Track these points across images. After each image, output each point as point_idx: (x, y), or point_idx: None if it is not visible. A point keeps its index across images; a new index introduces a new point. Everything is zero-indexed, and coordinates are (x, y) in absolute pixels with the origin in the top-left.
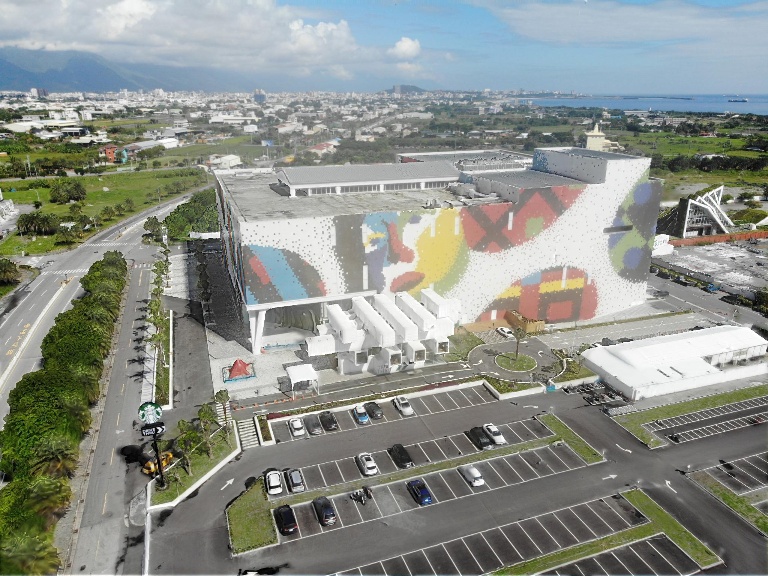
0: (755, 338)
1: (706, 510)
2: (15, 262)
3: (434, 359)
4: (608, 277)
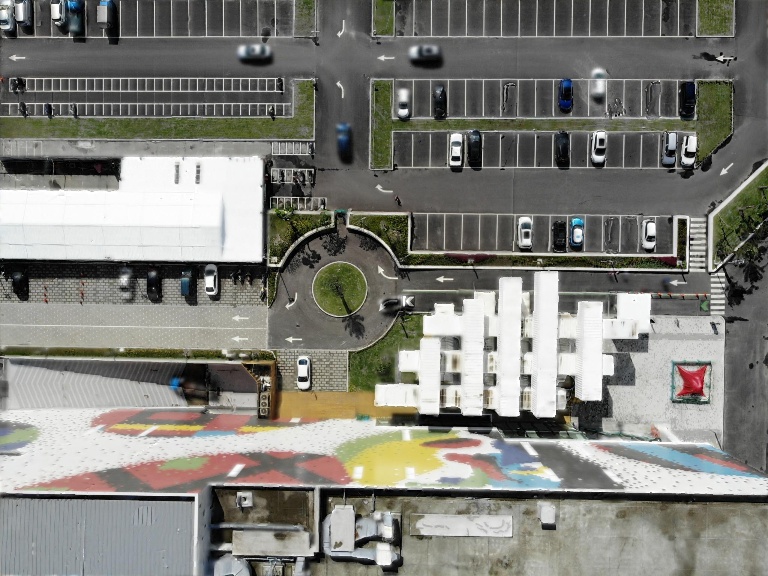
0: (0, 202)
1: None
2: None
3: None
4: None
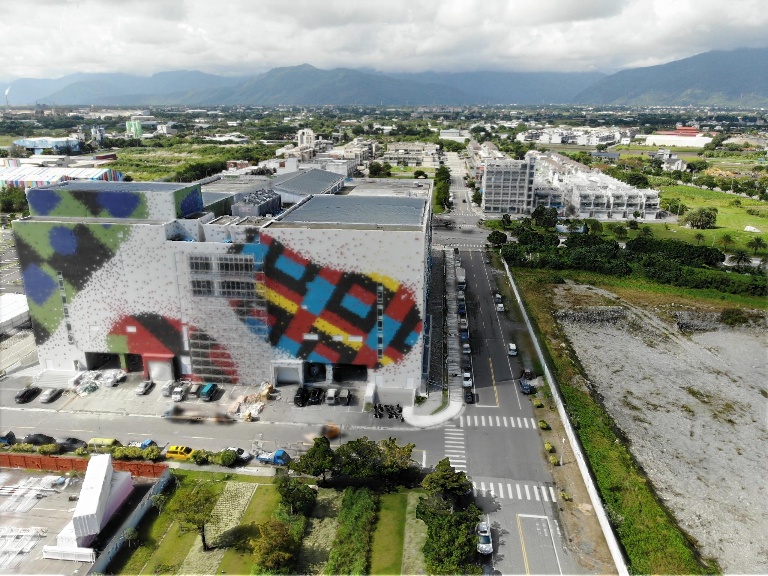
0: None
1: None
2: None
3: None
4: None
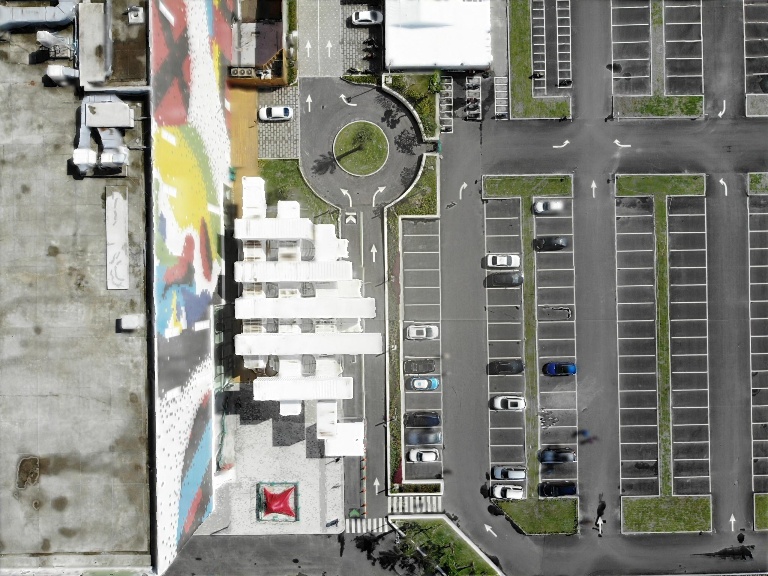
0: None
1: (657, 140)
2: None
3: None
4: None
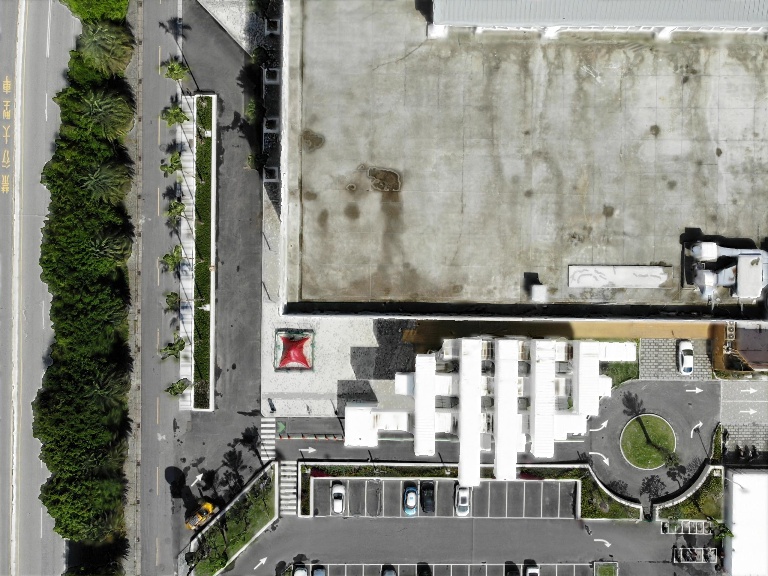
0: None
1: None
2: None
3: None
4: None
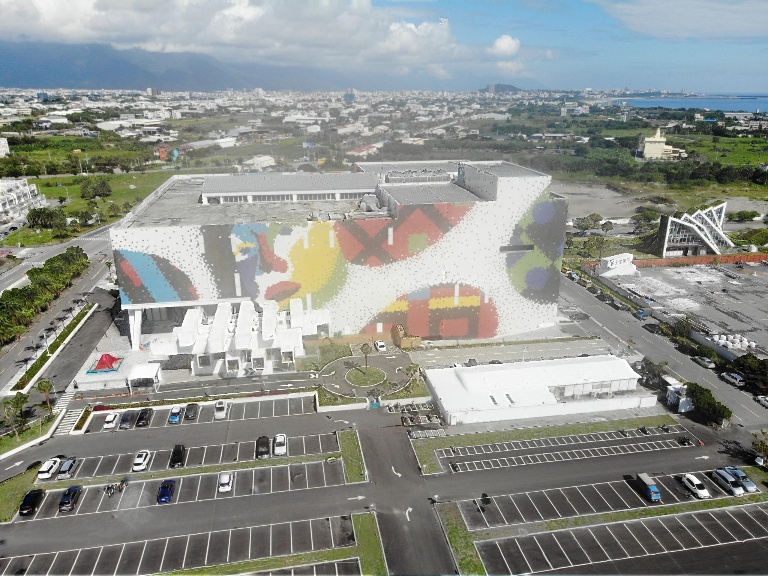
0: (625, 371)
1: (422, 541)
2: (8, 252)
3: (284, 367)
4: (509, 296)
